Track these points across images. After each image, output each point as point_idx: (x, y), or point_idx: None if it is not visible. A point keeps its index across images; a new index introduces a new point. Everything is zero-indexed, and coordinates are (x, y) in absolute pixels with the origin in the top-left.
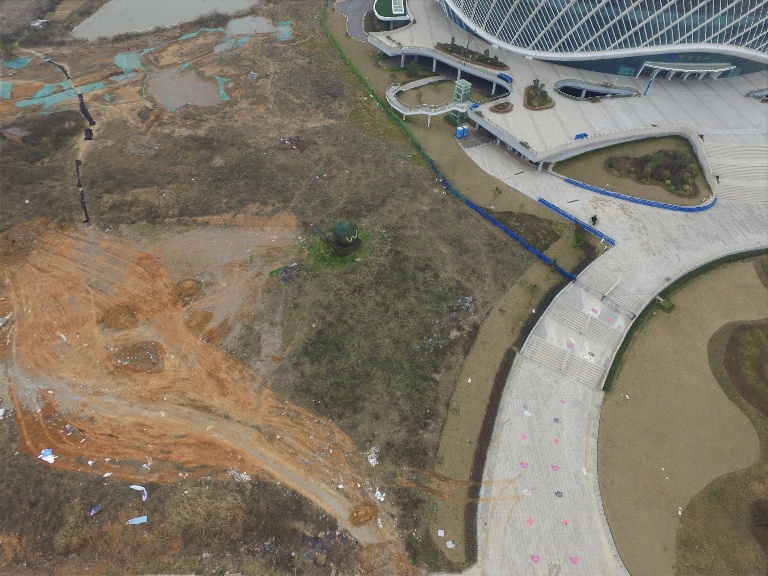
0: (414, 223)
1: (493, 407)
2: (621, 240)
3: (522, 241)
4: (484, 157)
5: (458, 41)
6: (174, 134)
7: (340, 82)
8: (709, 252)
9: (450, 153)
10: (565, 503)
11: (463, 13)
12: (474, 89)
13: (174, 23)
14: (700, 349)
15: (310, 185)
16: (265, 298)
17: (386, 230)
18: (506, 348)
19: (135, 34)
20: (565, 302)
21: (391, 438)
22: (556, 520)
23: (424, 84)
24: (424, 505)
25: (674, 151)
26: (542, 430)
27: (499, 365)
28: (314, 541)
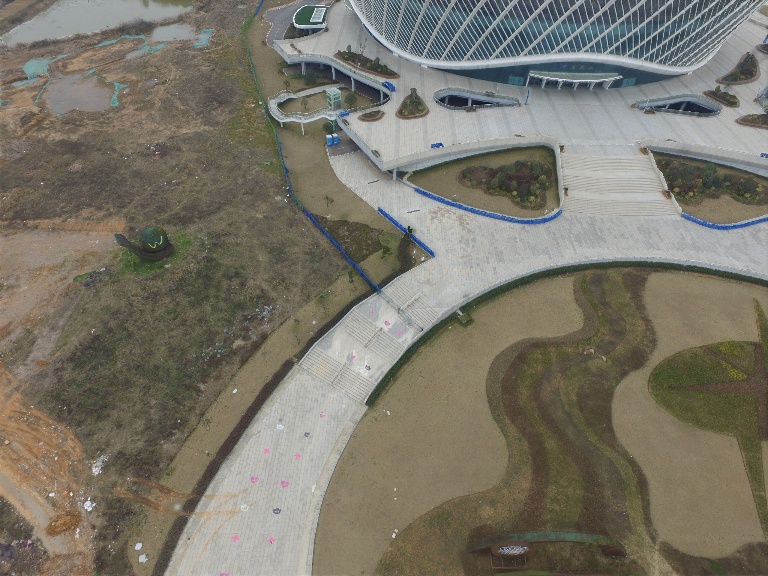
0: (241, 230)
1: (245, 419)
2: (444, 252)
3: (342, 251)
4: (345, 165)
5: (361, 49)
6: (47, 139)
7: (234, 89)
8: (529, 266)
9: (312, 161)
10: (279, 520)
11: (367, 21)
12: (367, 97)
13: (98, 30)
14: (483, 366)
15: (154, 191)
16: (59, 302)
17: (208, 237)
18: (286, 359)
19: (54, 41)
20: (361, 314)
21: (126, 447)
22: (262, 538)
23: (319, 92)
24: (133, 517)
25: (532, 162)
26: (288, 444)
27: (271, 376)
28: (5, 549)
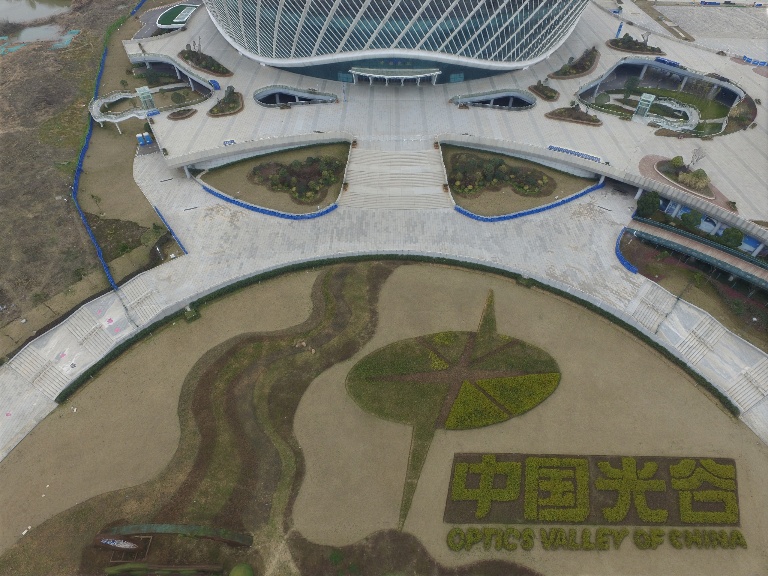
0: (3, 231)
1: None
2: (199, 248)
3: None
4: (148, 164)
5: (209, 48)
6: None
7: (71, 89)
8: (277, 261)
9: (114, 160)
10: None
11: None
12: None
13: None
14: (189, 361)
15: None
16: None
17: None
18: None
19: None
20: (88, 312)
21: None
22: None
23: (158, 91)
24: None
25: None
26: None
27: None
28: None
